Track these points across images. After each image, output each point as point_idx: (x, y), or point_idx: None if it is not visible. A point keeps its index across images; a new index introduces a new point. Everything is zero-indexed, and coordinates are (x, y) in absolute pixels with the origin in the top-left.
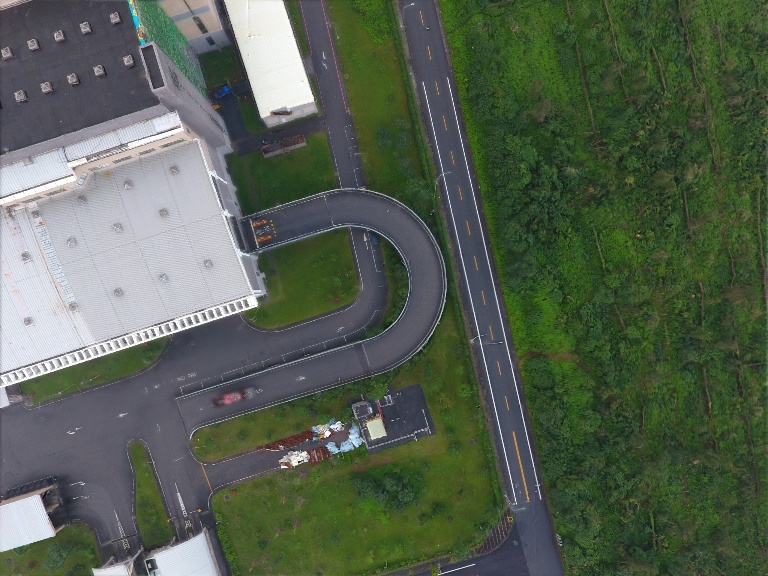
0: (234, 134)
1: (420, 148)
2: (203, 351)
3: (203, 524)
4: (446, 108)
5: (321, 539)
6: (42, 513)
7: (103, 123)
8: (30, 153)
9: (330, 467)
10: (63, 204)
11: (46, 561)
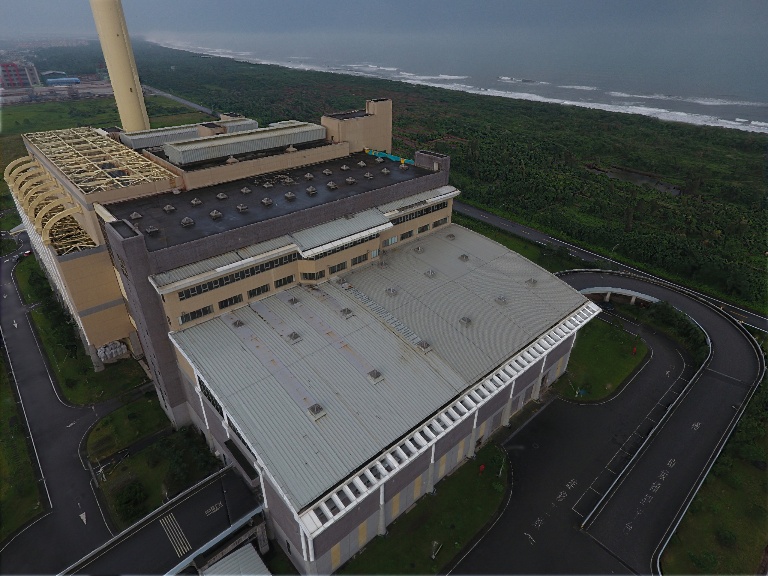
0: None
1: None
2: (557, 449)
3: None
4: None
5: None
6: None
7: (411, 180)
8: (353, 208)
9: None
10: (365, 272)
11: None
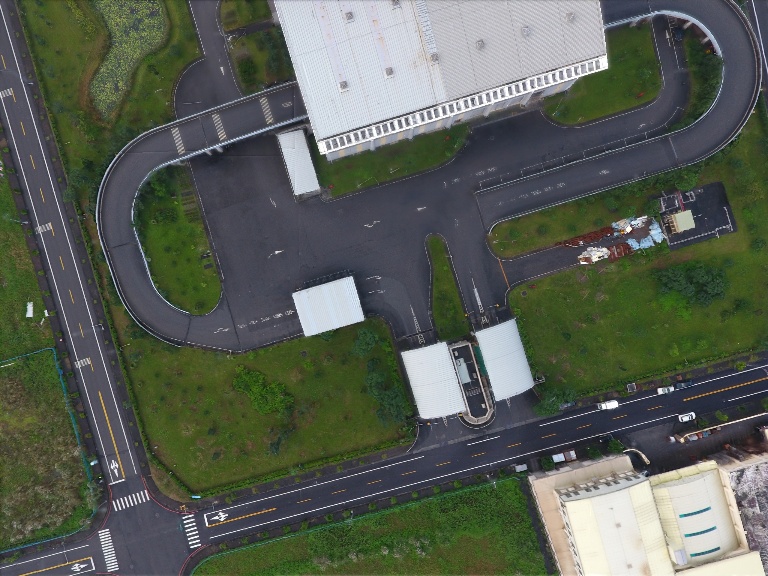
0: None
1: None
2: (503, 146)
3: (500, 320)
4: None
5: (621, 335)
6: (354, 295)
7: None
8: None
9: (631, 263)
10: None
11: (358, 343)
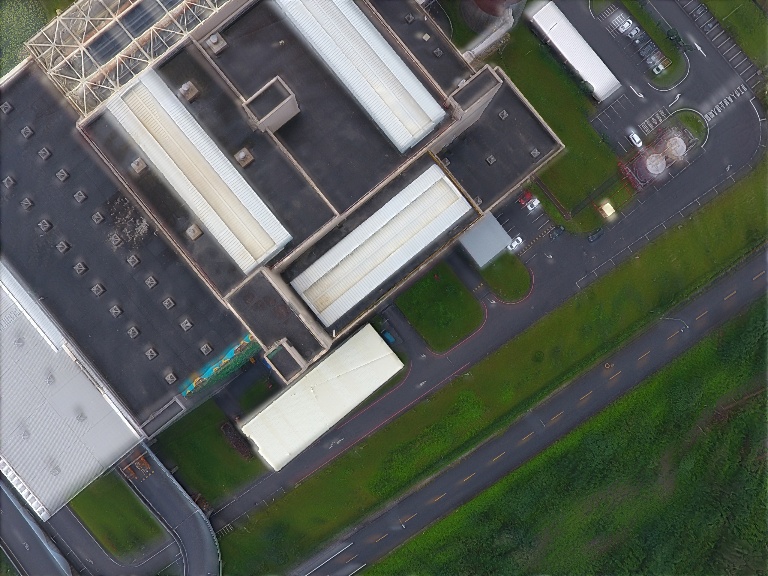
0: (234, 387)
1: (286, 571)
2: None
3: None
4: (337, 574)
5: None
6: None
7: (101, 381)
8: None
9: None
10: None
11: None
